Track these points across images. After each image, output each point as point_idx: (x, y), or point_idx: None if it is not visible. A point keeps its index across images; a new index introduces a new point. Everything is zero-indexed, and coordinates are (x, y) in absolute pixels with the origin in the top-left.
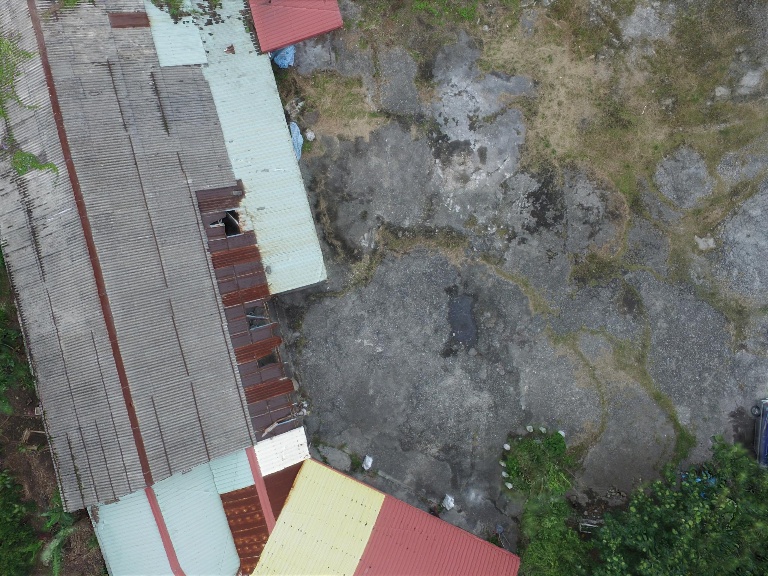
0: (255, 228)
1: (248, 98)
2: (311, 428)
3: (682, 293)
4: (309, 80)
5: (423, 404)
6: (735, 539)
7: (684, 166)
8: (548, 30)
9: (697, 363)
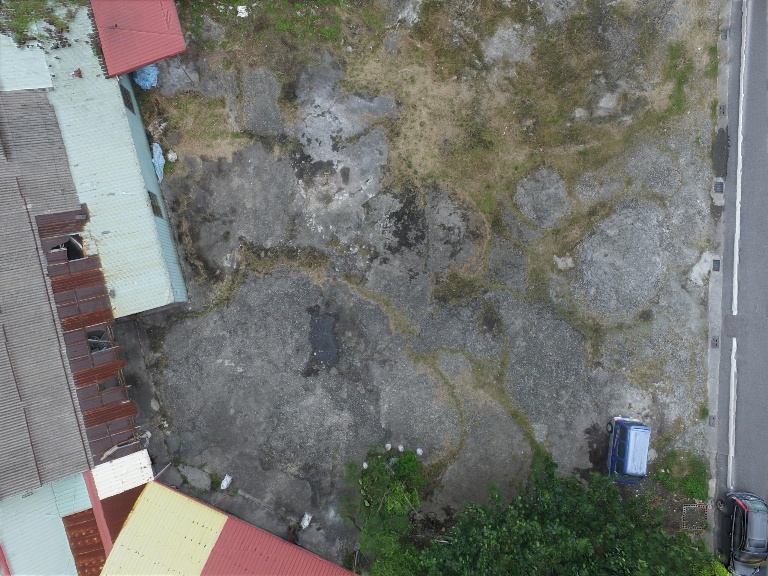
0: (100, 252)
1: (95, 122)
2: (171, 448)
3: (541, 312)
4: (172, 101)
5: (284, 423)
6: (534, 562)
7: (544, 186)
8: (411, 51)
9: (554, 381)
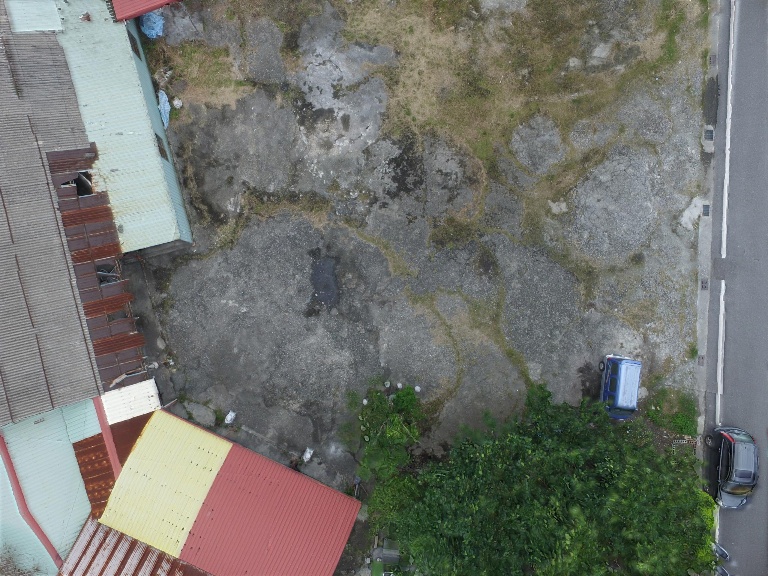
0: (108, 189)
1: (103, 64)
2: (177, 385)
3: (535, 255)
4: (177, 49)
5: (286, 362)
6: (526, 471)
7: (539, 133)
8: (410, 2)
9: (548, 321)
